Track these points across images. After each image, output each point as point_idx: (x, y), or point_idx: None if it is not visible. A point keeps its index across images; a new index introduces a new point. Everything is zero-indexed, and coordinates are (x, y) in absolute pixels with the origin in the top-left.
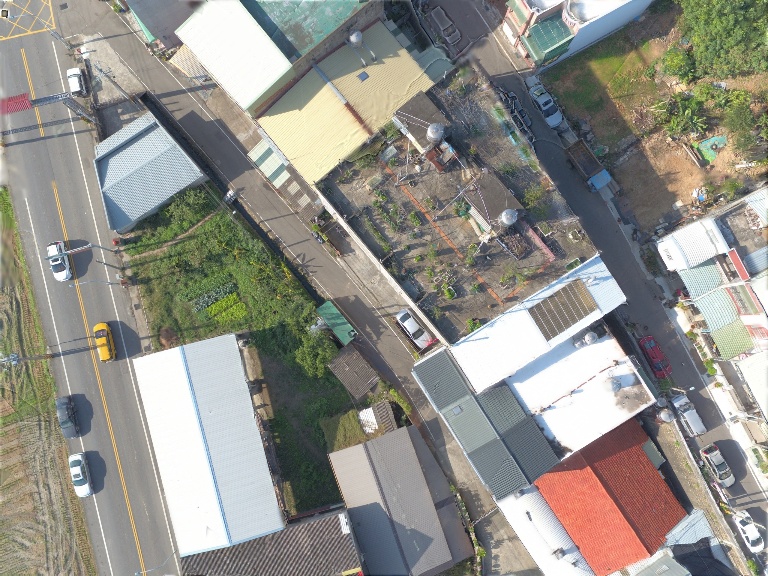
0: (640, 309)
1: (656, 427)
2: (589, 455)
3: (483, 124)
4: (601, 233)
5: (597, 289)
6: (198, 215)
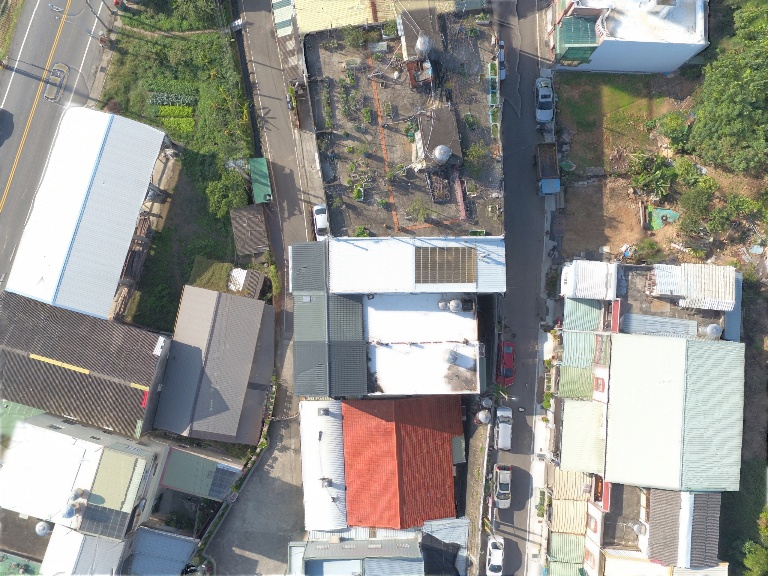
0: (519, 317)
1: (474, 428)
2: (401, 413)
3: (461, 52)
4: (525, 234)
5: (485, 266)
6: (201, 23)
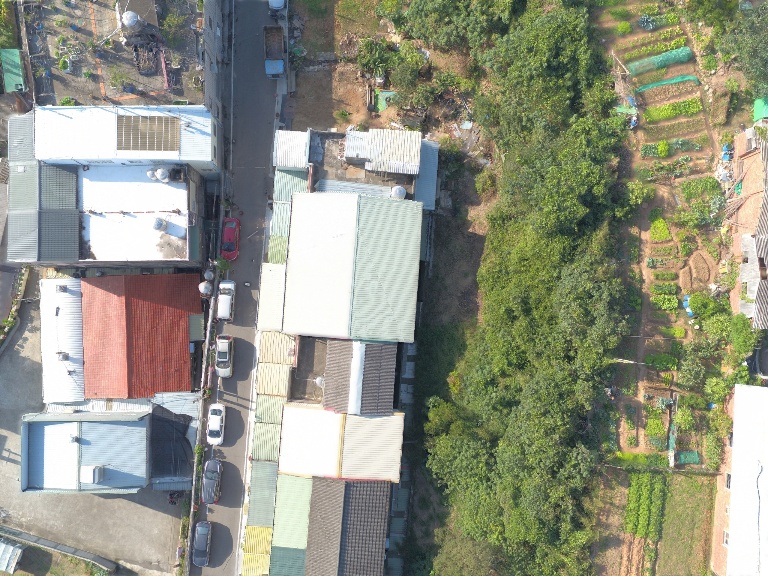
0: (247, 196)
1: None
2: (132, 288)
3: None
4: (256, 117)
5: (189, 136)
6: None
